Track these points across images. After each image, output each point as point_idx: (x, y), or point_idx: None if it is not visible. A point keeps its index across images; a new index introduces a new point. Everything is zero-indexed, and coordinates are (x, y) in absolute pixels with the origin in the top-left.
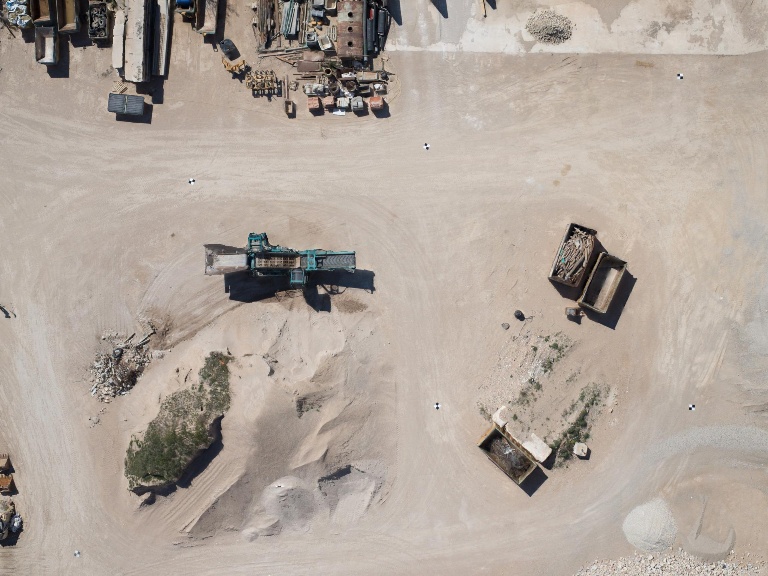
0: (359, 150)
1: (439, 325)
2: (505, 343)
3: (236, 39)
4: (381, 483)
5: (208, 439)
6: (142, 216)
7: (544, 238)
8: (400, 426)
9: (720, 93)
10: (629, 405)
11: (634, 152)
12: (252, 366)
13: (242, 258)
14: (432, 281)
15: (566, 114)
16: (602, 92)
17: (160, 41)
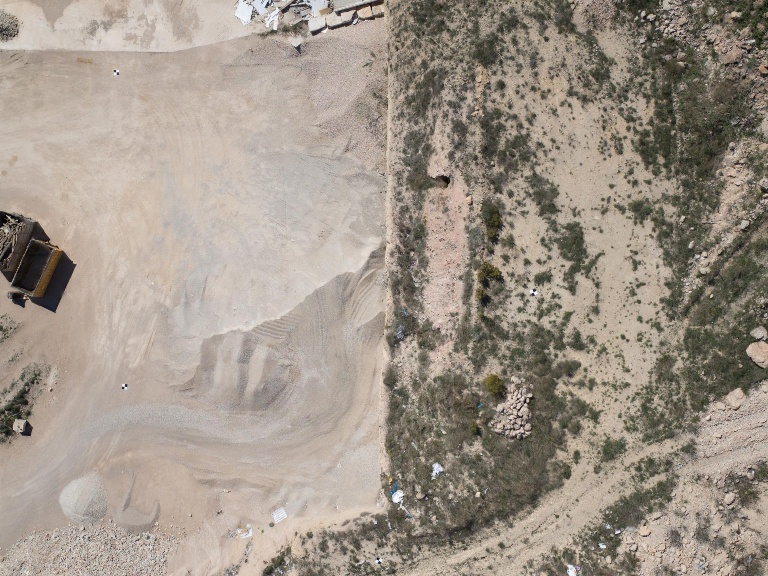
0: None
1: None
2: None
3: None
4: None
5: None
6: None
7: None
8: None
9: (152, 88)
10: (67, 384)
11: (75, 144)
12: None
13: None
14: None
15: (14, 108)
16: (46, 87)
17: None
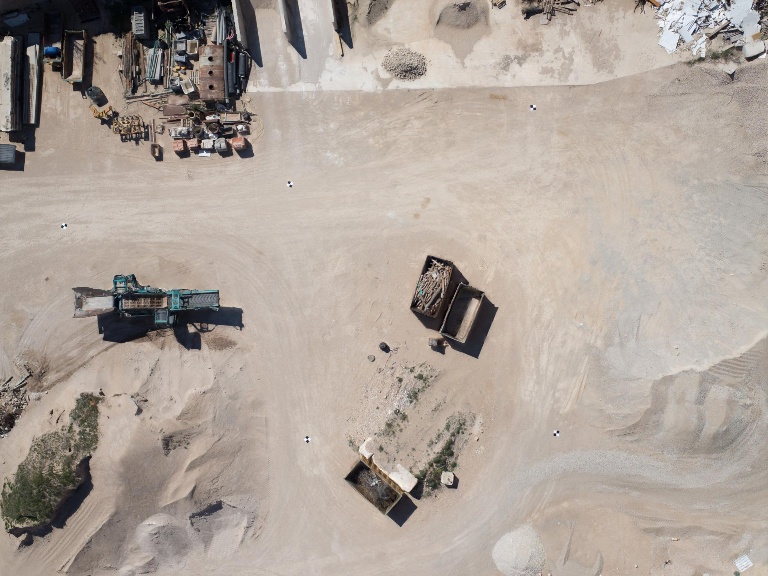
0: (225, 190)
1: (307, 359)
2: (371, 375)
3: (104, 86)
4: (254, 518)
5: (76, 480)
6: (17, 261)
7: (406, 270)
8: (271, 460)
9: (572, 123)
10: (495, 433)
11: (491, 183)
12: (120, 406)
13: (109, 300)
14: (299, 316)
15: (424, 148)
16: (458, 125)
17: (30, 90)
